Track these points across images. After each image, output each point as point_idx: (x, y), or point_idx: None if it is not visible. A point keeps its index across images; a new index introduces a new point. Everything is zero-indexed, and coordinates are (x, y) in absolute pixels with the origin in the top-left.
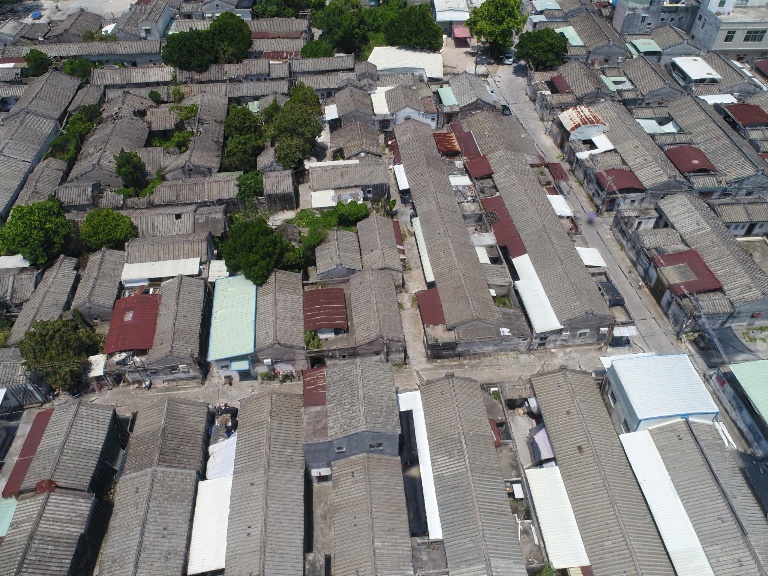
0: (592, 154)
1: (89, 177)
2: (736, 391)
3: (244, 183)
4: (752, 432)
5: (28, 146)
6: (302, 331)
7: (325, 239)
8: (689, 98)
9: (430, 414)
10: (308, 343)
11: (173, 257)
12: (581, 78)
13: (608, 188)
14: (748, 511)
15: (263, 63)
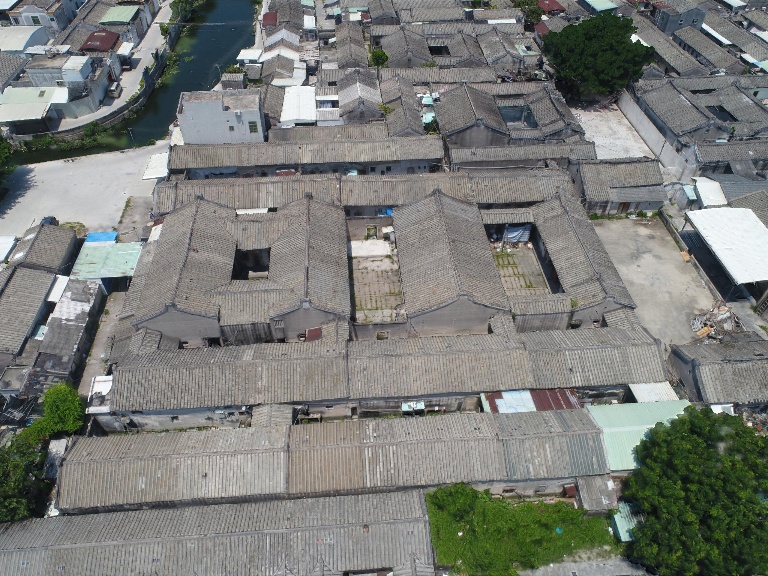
0: None
1: None
2: None
3: None
4: None
5: None
6: None
7: None
8: None
9: None
10: (637, 8)
11: None
12: None
13: None
14: None
15: None
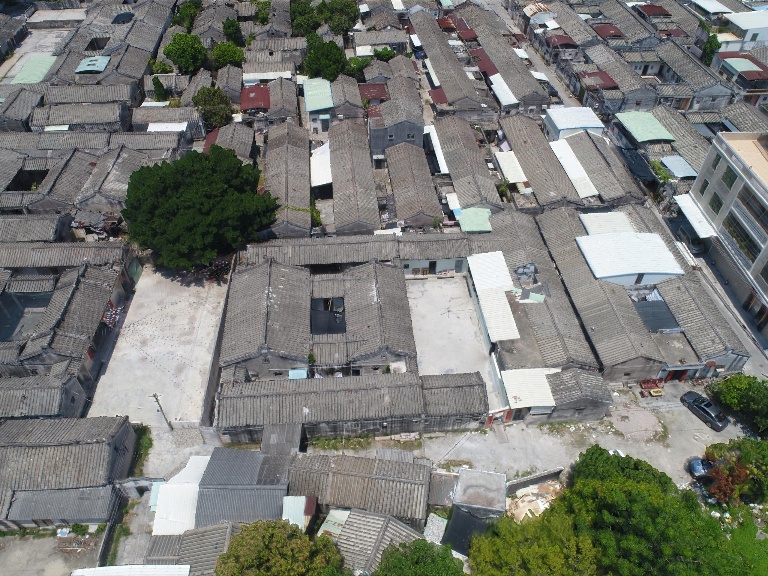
0: (544, 30)
1: (205, 36)
2: (619, 129)
3: (312, 38)
4: (626, 147)
5: (158, 20)
6: (361, 101)
7: (369, 65)
8: (613, 0)
9: (440, 131)
10: (365, 106)
11: (273, 71)
12: None
13: (553, 44)
14: (614, 163)
15: None
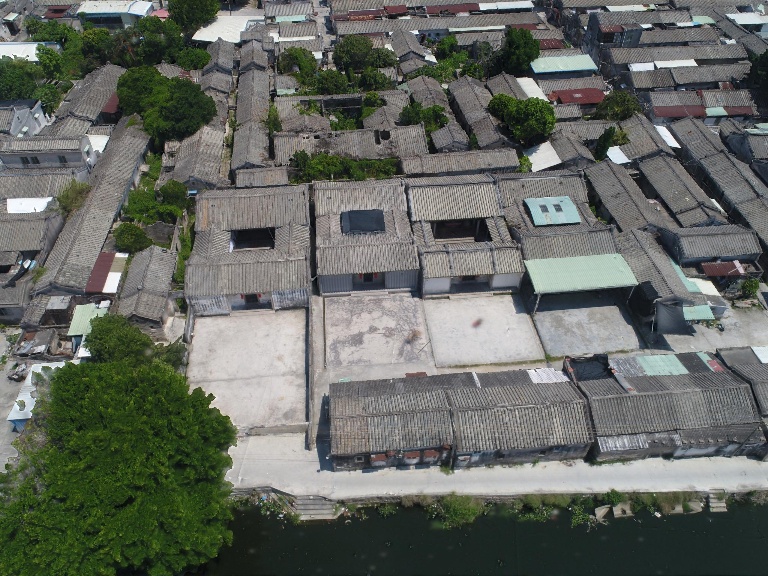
0: None
1: None
2: None
3: None
4: None
5: None
6: None
7: None
8: None
9: None
10: None
11: None
12: None
13: None
14: None
15: (216, 78)
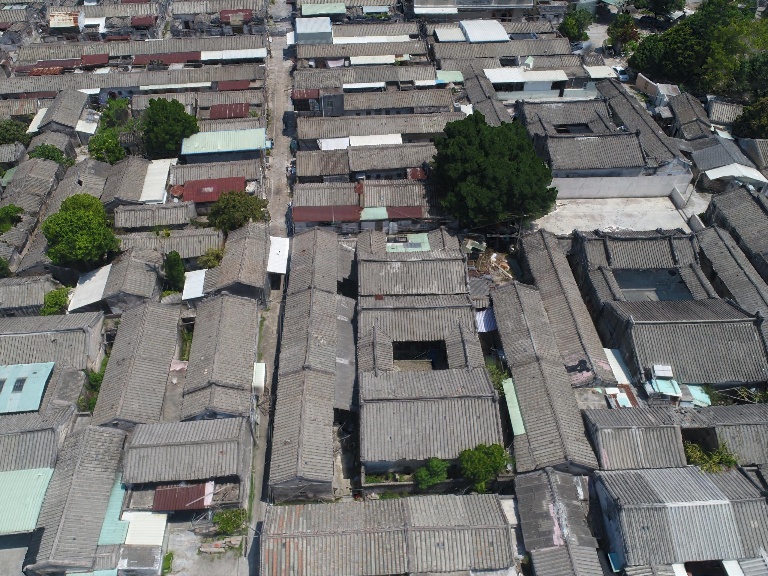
0: (107, 25)
1: None
2: None
3: (49, 151)
4: None
5: None
6: None
7: None
8: None
9: None
10: None
11: (142, 177)
12: (1, 14)
13: None
14: None
15: None
